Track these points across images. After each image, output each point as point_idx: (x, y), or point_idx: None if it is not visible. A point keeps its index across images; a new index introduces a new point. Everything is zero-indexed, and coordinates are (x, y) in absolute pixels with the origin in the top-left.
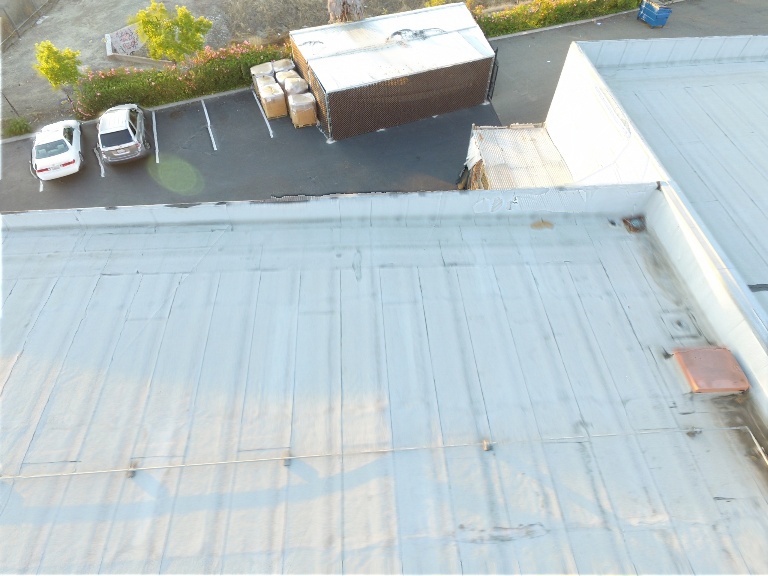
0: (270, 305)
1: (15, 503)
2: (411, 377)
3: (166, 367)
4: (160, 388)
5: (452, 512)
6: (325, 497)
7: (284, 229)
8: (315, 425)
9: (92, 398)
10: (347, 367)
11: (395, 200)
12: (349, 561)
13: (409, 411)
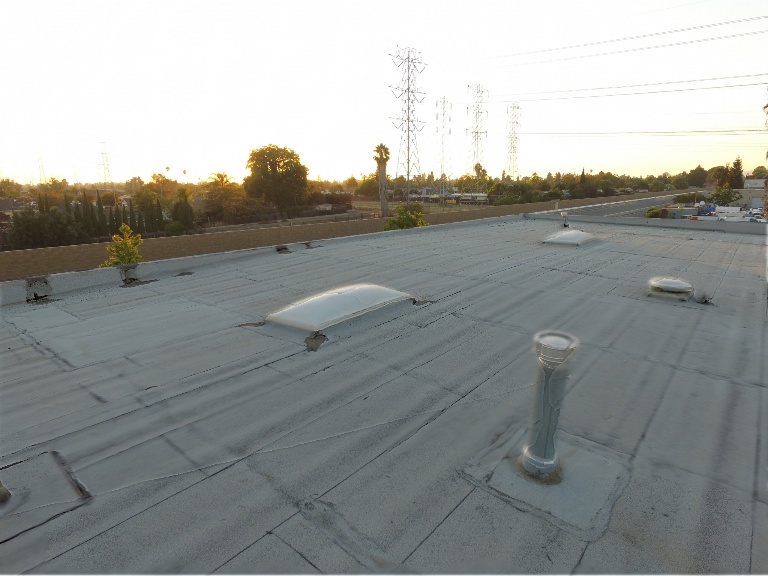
0: None
1: None
2: None
3: None
4: (698, 237)
5: None
6: None
7: None
8: None
9: None
10: None
11: None
12: None
13: None
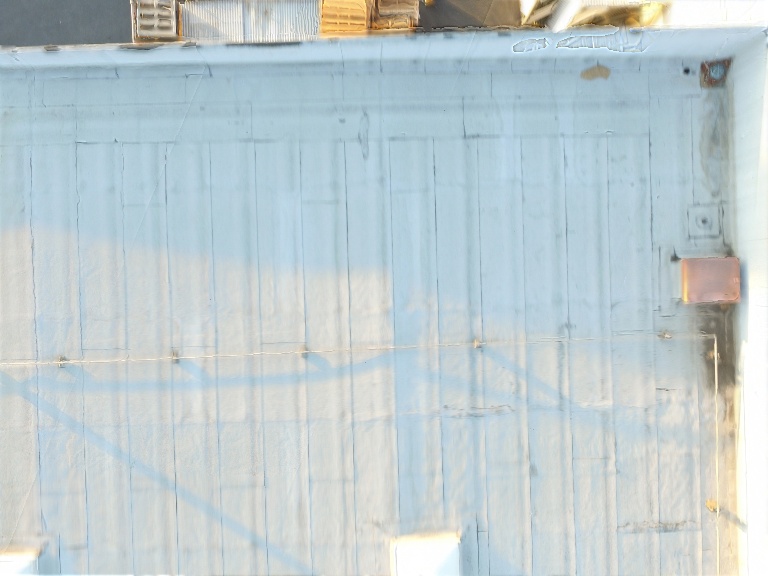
0: (270, 190)
1: (90, 381)
2: (415, 278)
3: (179, 262)
4: (179, 283)
5: (439, 397)
6: (338, 383)
7: (274, 75)
8: (326, 323)
9: (119, 292)
10: (354, 266)
11: (413, 42)
12: (358, 429)
13: (411, 312)
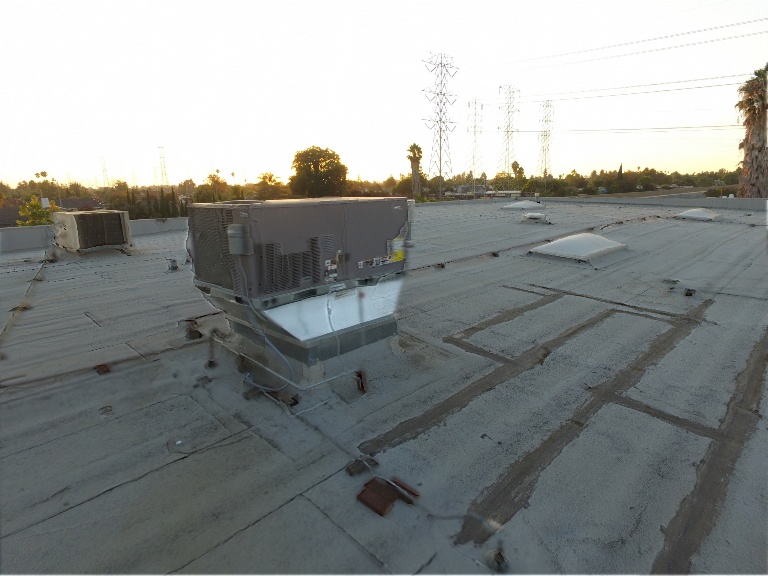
0: None
1: None
2: None
3: None
4: None
5: None
6: None
7: None
8: (681, 210)
9: None
10: None
11: (740, 199)
12: None
13: None
